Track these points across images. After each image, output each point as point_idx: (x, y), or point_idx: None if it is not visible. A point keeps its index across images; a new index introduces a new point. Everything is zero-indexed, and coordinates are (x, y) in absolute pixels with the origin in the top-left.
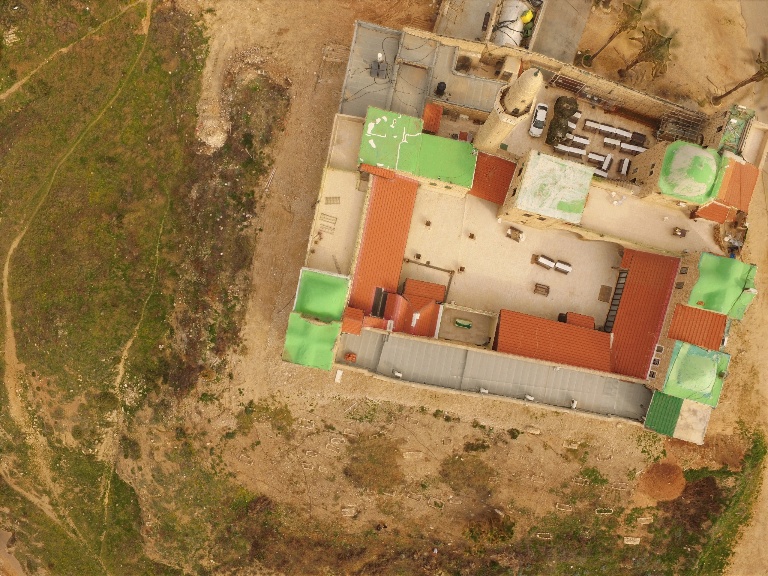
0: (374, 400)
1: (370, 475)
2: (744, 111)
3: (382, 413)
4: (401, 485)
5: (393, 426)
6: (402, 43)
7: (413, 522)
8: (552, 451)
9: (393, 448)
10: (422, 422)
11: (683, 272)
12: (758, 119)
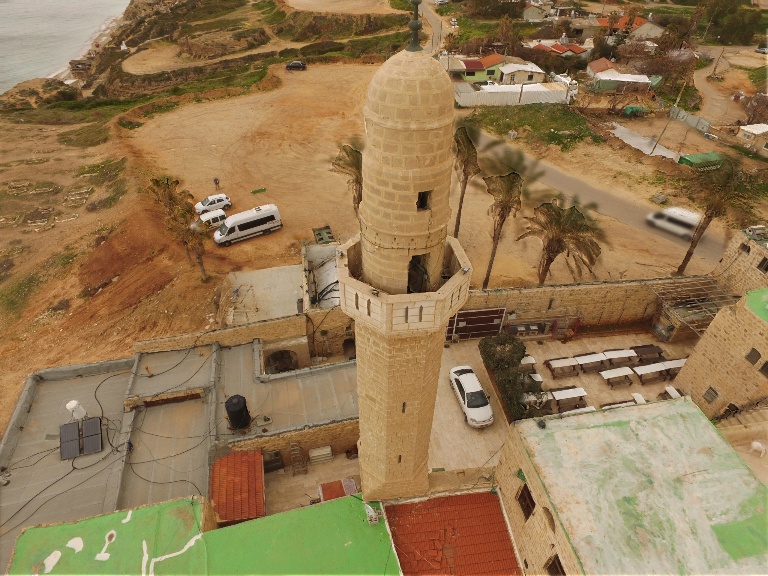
0: None
1: None
2: (765, 231)
3: None
4: None
5: None
6: (135, 371)
7: None
8: None
9: None
10: None
11: None
12: None
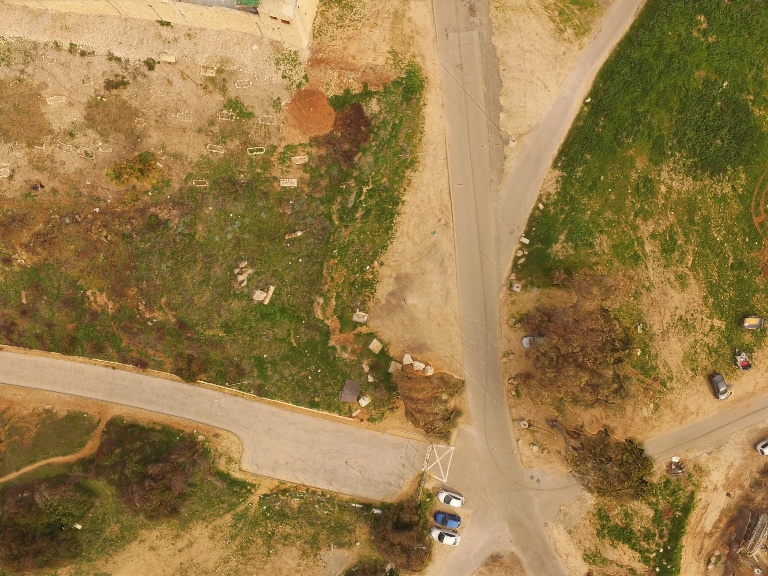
0: (5, 36)
1: (17, 127)
2: None
3: (18, 53)
4: (49, 135)
5: (32, 69)
6: None
7: (68, 178)
8: (191, 81)
9: (35, 94)
10: (59, 60)
11: None
12: None
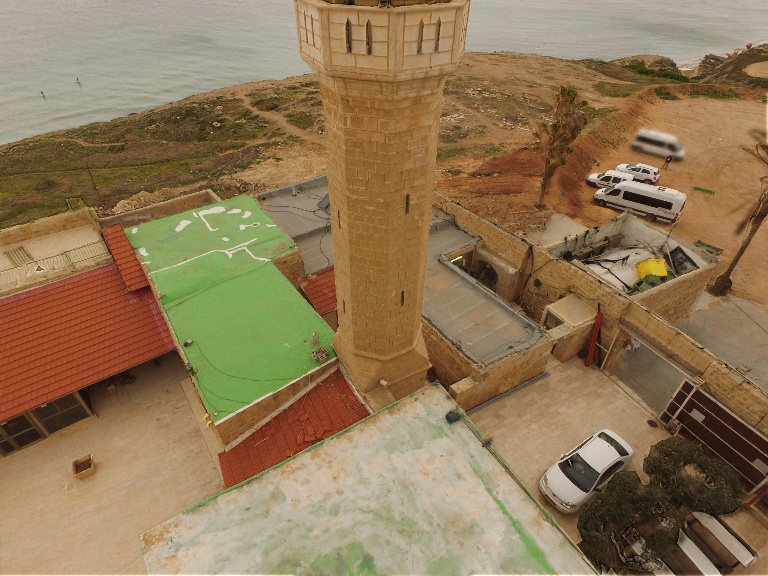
0: None
1: None
2: None
3: None
4: None
5: None
6: None
7: None
8: None
9: None
10: None
11: None
12: None
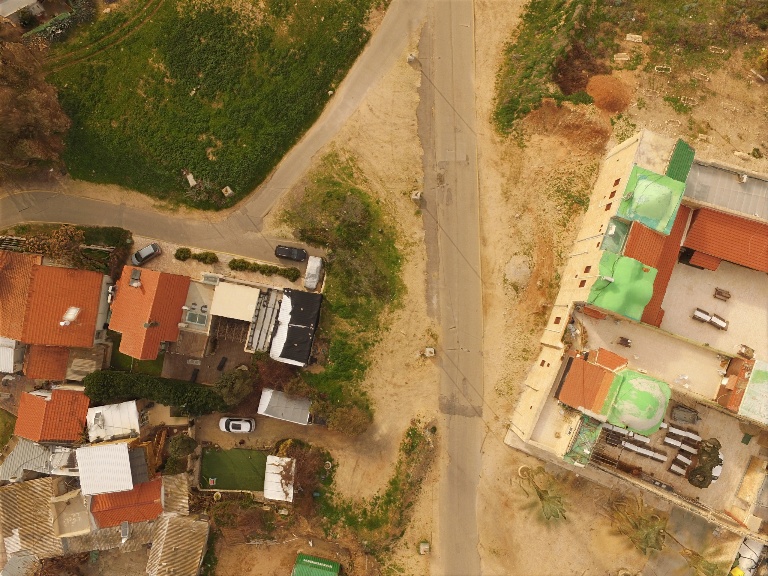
0: None
1: None
2: None
3: None
4: None
5: None
6: None
7: None
8: (720, 133)
9: None
10: None
11: None
12: (480, 450)
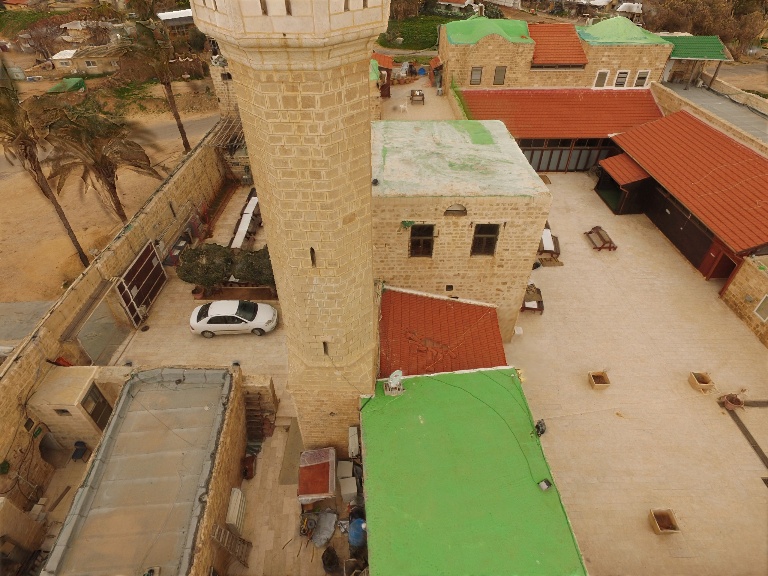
0: None
1: None
2: (222, 58)
3: None
4: None
5: None
6: None
7: None
8: None
9: None
10: None
11: (479, 76)
12: None
